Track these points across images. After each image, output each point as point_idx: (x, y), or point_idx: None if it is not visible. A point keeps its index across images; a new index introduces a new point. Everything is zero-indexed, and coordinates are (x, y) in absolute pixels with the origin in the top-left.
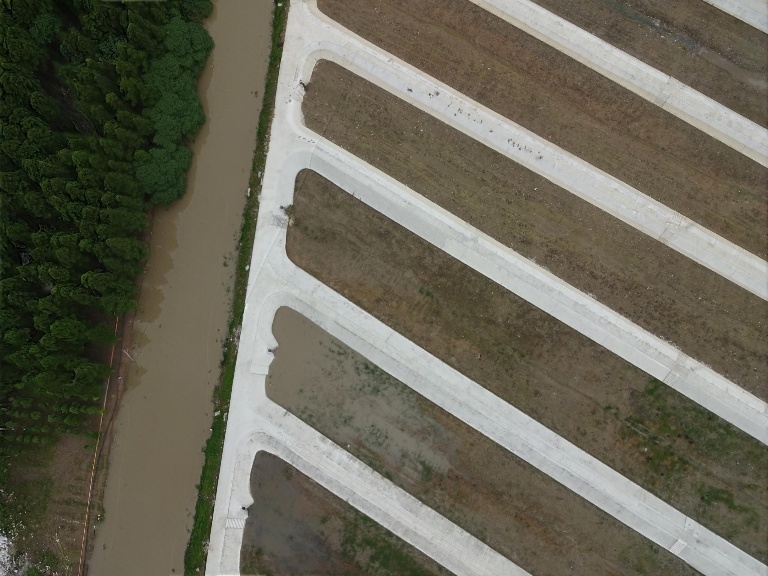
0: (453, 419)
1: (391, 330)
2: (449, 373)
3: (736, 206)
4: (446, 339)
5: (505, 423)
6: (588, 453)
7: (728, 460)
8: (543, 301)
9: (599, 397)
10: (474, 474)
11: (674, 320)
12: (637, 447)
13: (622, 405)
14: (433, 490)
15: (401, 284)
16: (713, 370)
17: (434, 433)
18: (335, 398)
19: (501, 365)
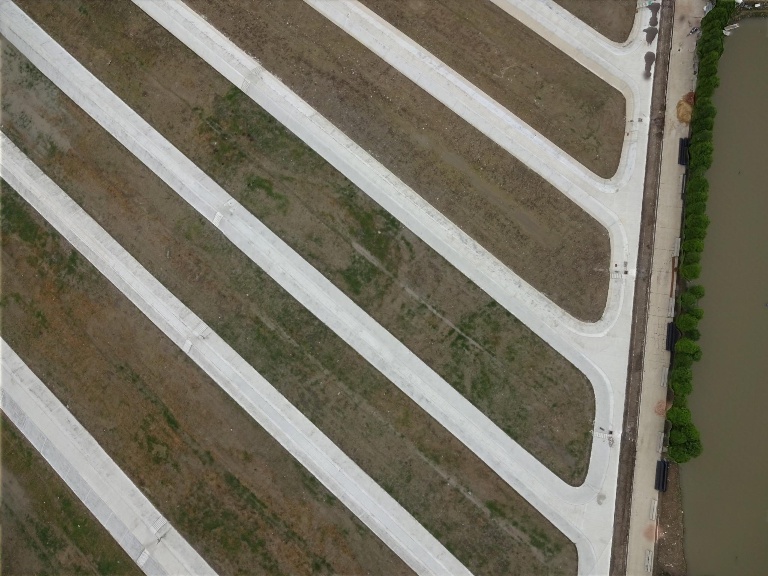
0: (80, 110)
1: (50, 38)
2: (83, 73)
3: None
4: (89, 48)
5: (112, 113)
6: (171, 142)
7: (276, 156)
8: (164, 19)
9: (191, 100)
10: (85, 154)
11: (263, 40)
12: (209, 141)
13: (206, 107)
14: (54, 164)
15: (67, 3)
16: (282, 82)
17: (64, 120)
18: (1, 89)
19: (124, 70)
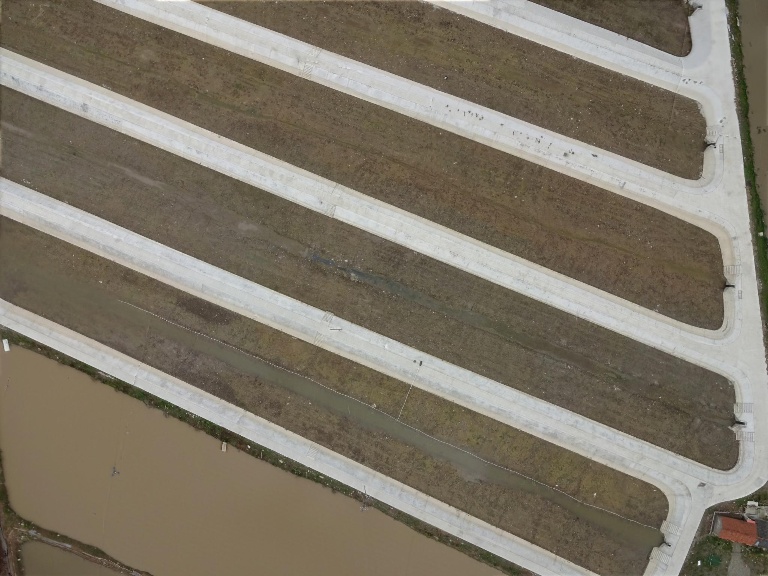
0: None
1: None
2: None
3: (255, 96)
4: None
5: None
6: None
7: None
8: None
9: None
10: None
11: None
12: None
13: None
14: None
15: None
16: None
17: None
18: None
19: None
